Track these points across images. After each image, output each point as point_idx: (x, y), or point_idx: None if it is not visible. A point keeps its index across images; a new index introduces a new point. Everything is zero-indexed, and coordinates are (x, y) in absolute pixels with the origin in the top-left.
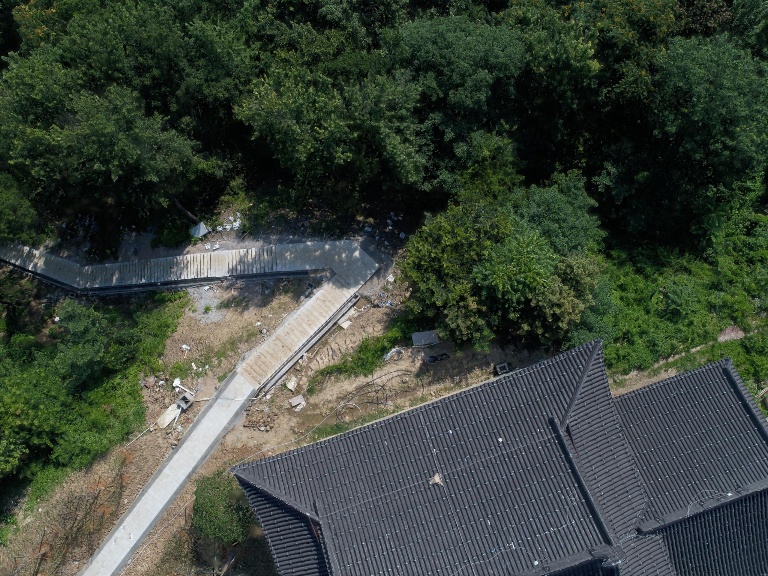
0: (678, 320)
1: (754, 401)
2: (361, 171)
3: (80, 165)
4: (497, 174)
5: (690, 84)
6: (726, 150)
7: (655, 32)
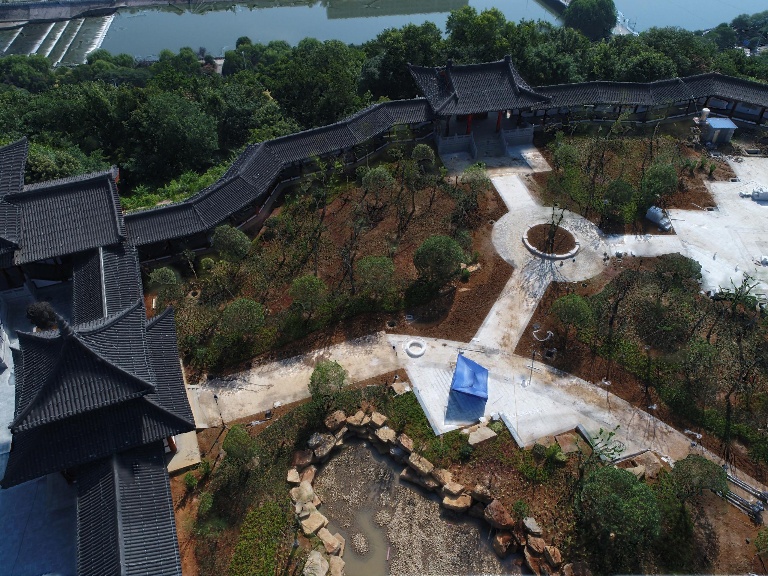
0: (134, 197)
1: (117, 173)
2: None
3: None
4: (55, 149)
5: (149, 103)
6: None
7: None
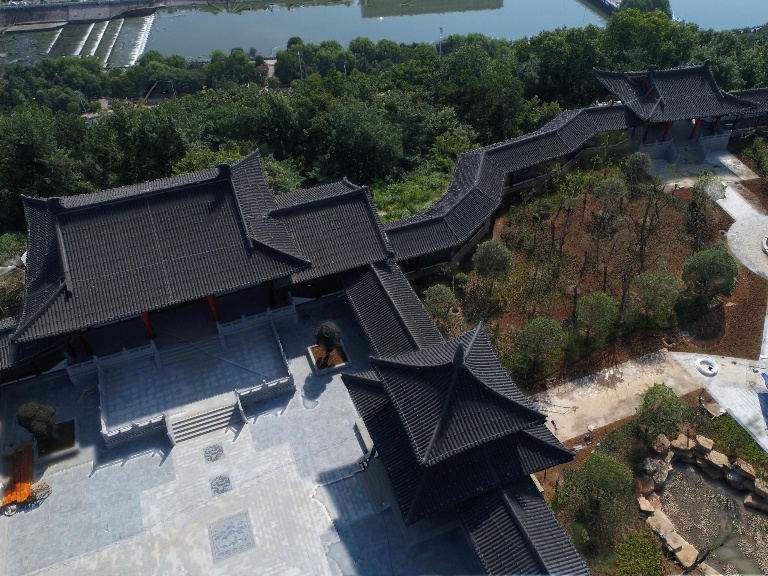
0: None
1: None
2: (170, 168)
3: (6, 161)
4: None
5: (337, 111)
6: (358, 132)
7: (327, 106)
